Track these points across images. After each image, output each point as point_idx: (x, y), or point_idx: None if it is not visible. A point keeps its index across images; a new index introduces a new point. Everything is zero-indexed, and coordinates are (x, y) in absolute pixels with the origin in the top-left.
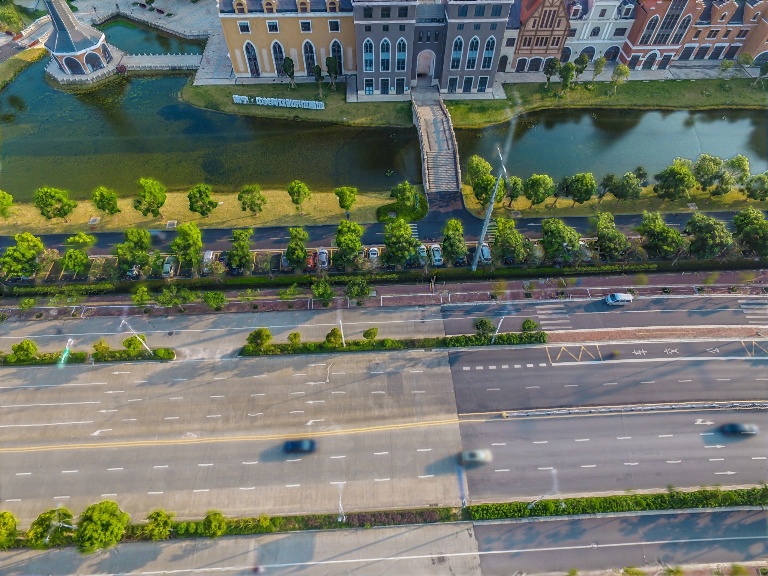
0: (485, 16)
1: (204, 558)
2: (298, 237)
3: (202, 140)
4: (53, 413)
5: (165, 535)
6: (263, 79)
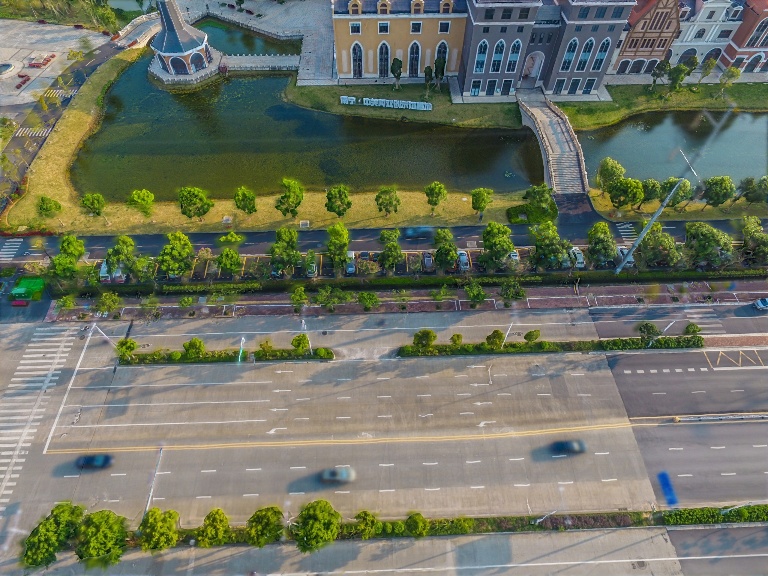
0: (605, 18)
1: (403, 558)
2: (445, 238)
3: (314, 140)
4: (225, 411)
5: (366, 535)
6: (365, 80)
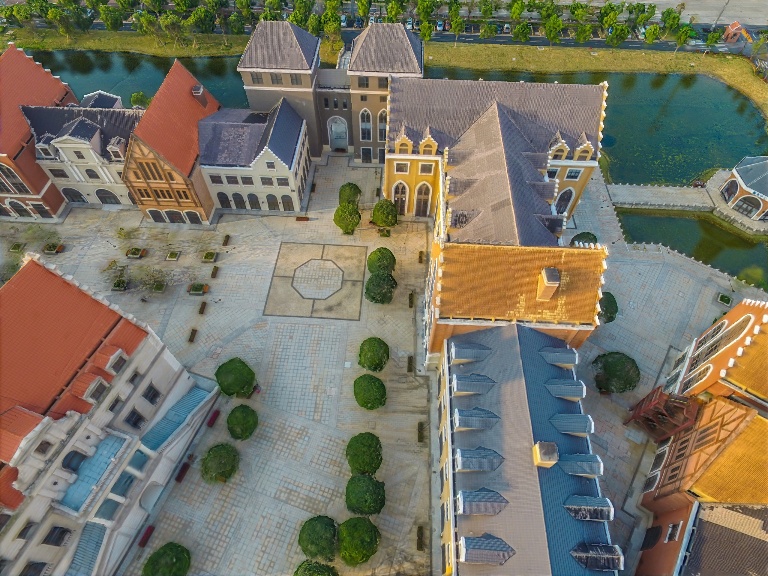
0: None
1: None
2: None
3: None
4: None
5: None
6: None
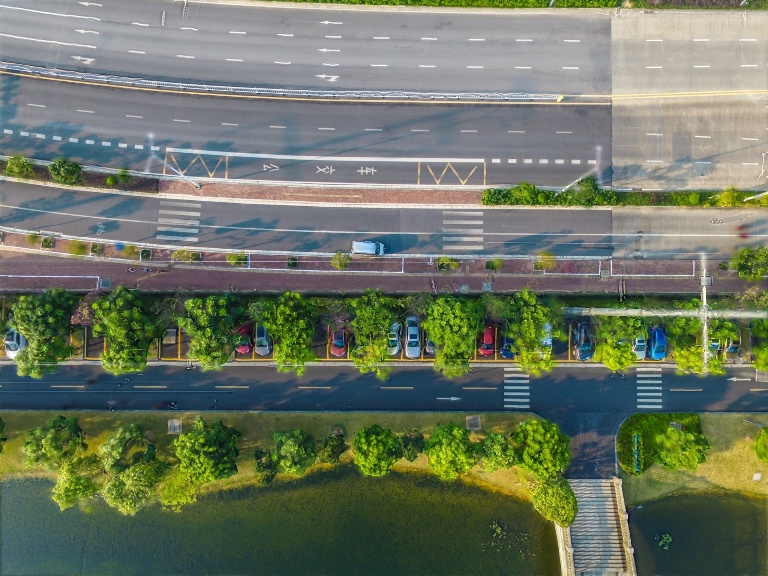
0: None
1: None
2: None
3: None
4: None
5: None
6: None
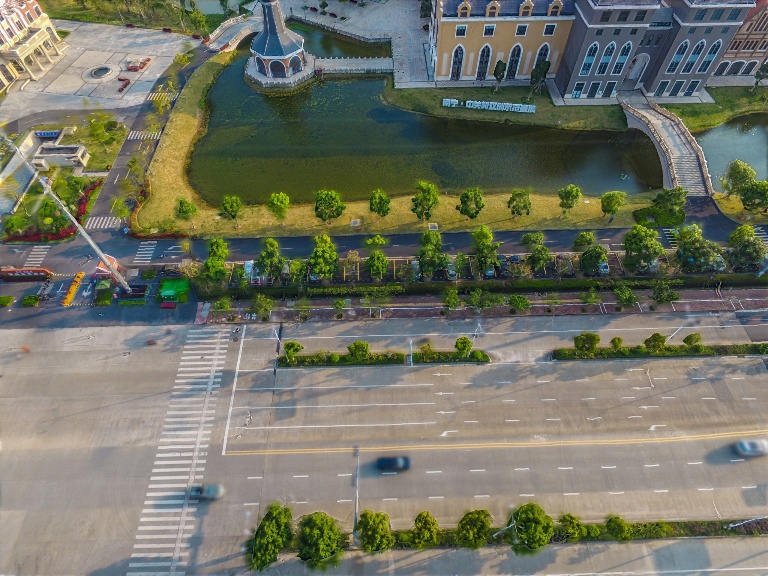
0: (720, 20)
1: (602, 562)
2: (590, 241)
3: (422, 143)
4: (393, 413)
5: None
6: (462, 82)
